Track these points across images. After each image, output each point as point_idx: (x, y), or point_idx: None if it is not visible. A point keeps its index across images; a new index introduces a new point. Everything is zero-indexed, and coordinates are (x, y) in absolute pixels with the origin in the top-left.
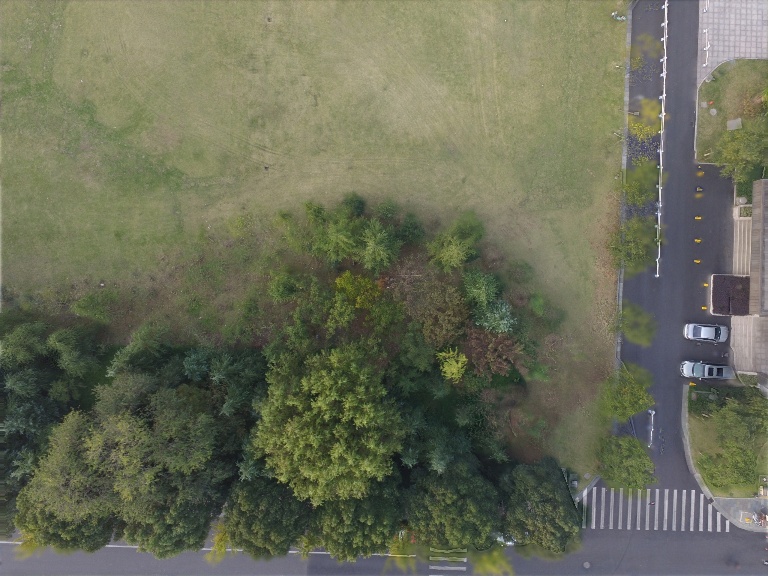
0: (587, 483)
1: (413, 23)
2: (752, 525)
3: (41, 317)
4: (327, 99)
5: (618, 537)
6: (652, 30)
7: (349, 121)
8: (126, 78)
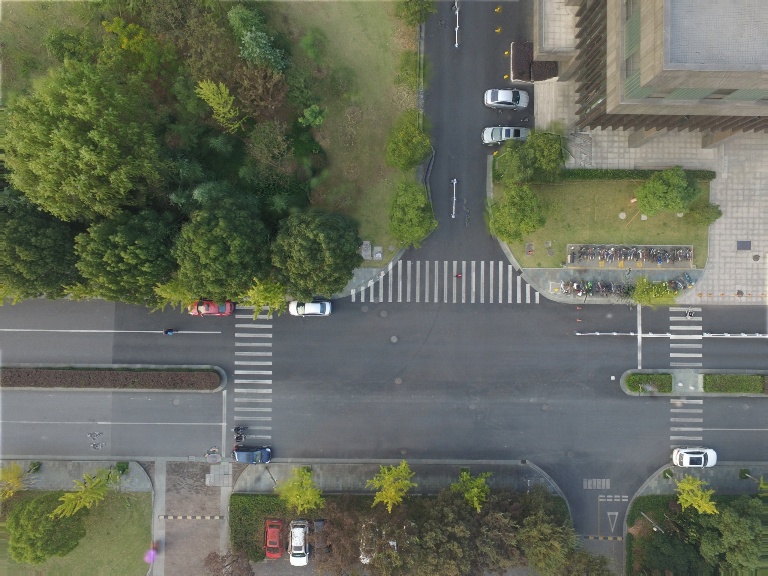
0: (392, 256)
1: None
2: (562, 295)
3: None
4: None
5: (425, 310)
6: None
7: None
8: None
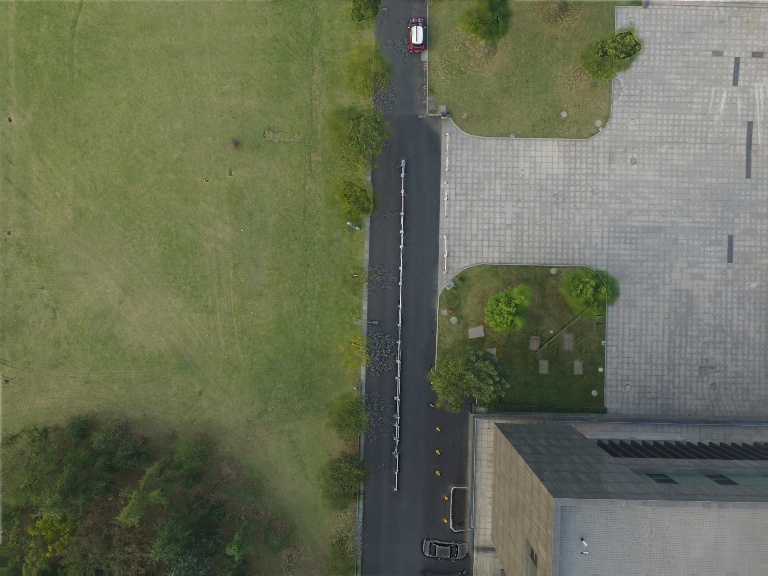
0: None
1: (149, 235)
2: None
3: None
4: (65, 312)
5: None
6: (391, 237)
7: (86, 335)
8: None
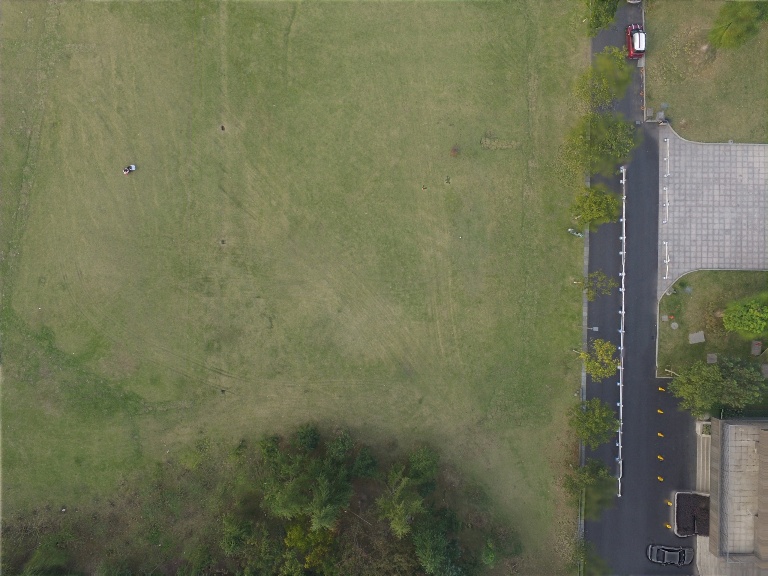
0: None
1: (367, 243)
2: None
3: (3, 554)
4: (282, 321)
5: None
6: (610, 243)
7: (304, 343)
8: (83, 305)
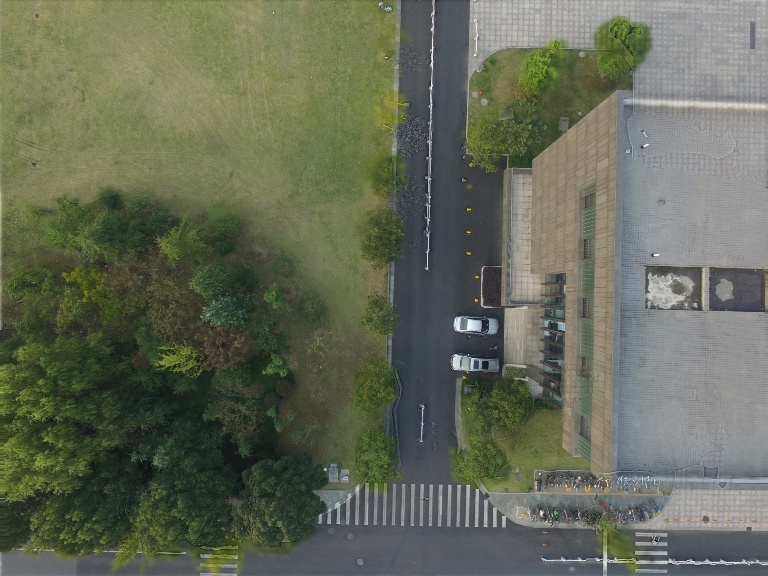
0: (359, 479)
1: (180, 17)
2: (528, 520)
3: None
4: (94, 94)
5: (391, 533)
6: (422, 20)
7: (115, 116)
8: None
